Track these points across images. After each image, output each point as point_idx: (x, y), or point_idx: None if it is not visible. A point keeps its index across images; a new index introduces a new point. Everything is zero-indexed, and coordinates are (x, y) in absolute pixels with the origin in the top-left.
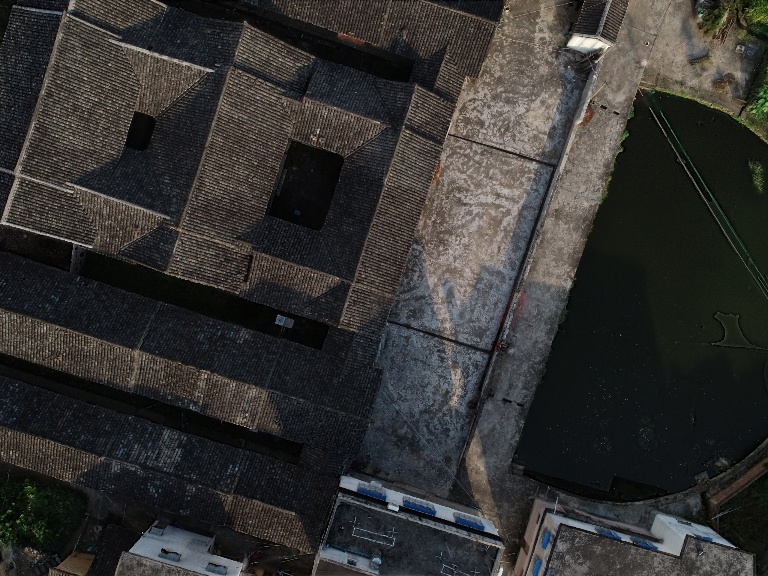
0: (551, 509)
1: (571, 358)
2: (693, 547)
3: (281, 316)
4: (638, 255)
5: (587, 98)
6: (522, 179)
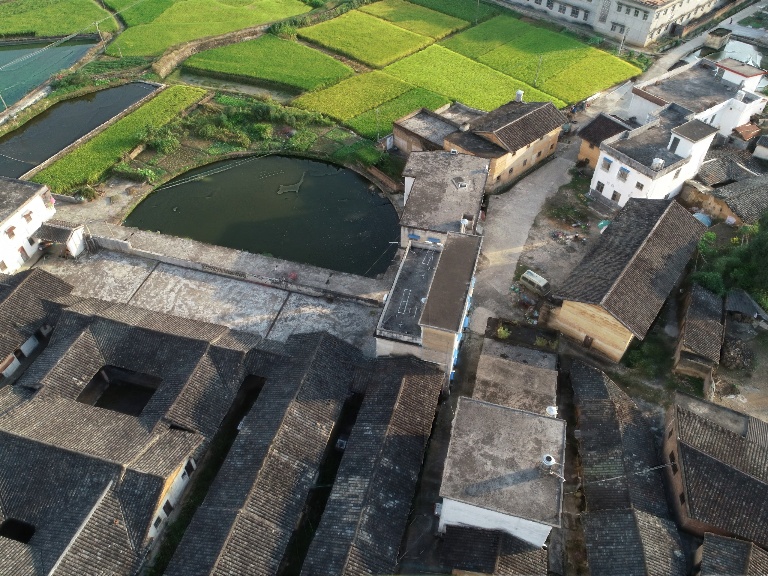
0: (398, 245)
1: (300, 255)
2: (408, 173)
3: (239, 425)
4: (233, 225)
5: (114, 240)
6: (163, 278)
